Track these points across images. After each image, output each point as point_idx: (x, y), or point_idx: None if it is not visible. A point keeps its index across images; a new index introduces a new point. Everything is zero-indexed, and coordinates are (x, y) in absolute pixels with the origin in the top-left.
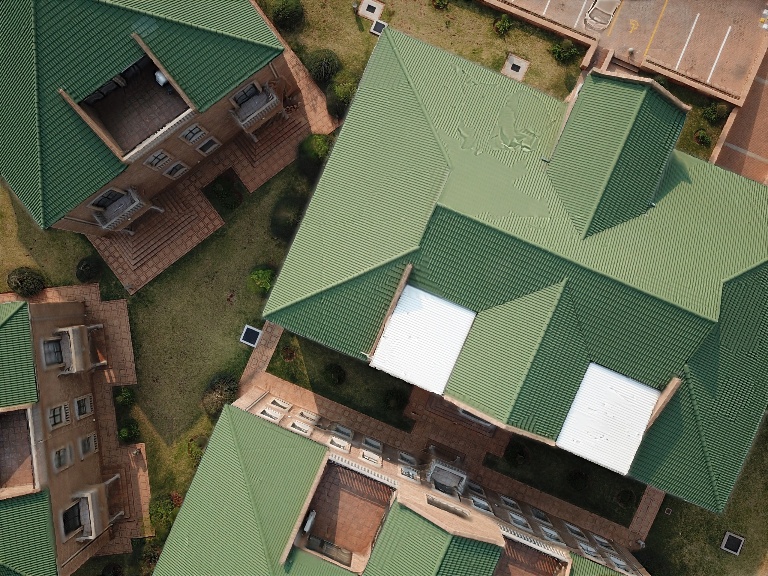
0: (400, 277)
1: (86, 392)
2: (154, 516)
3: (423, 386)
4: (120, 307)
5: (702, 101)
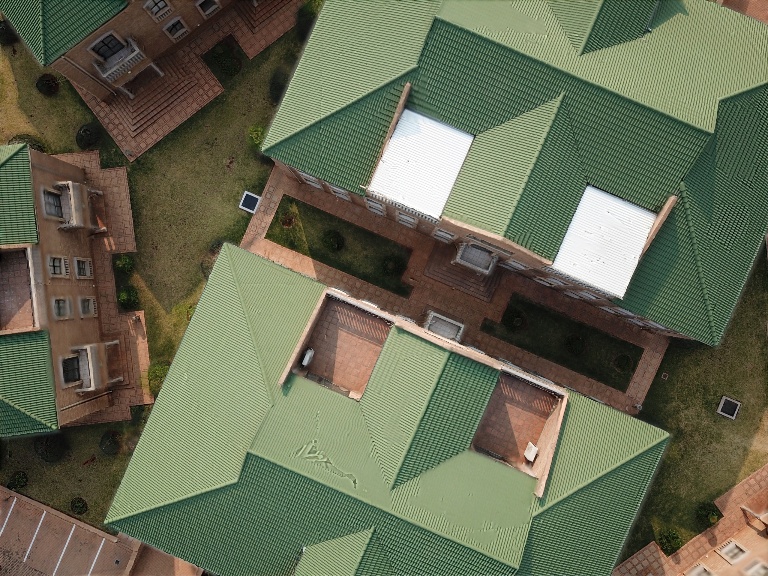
0: (398, 100)
1: (86, 256)
2: (153, 381)
3: (421, 209)
4: (120, 175)
5: None
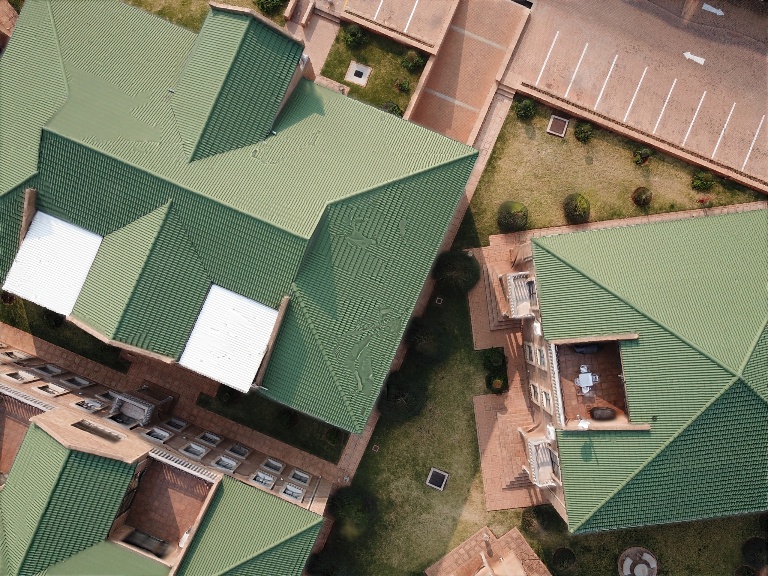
0: None
1: None
2: None
3: (52, 308)
4: None
5: (401, 50)
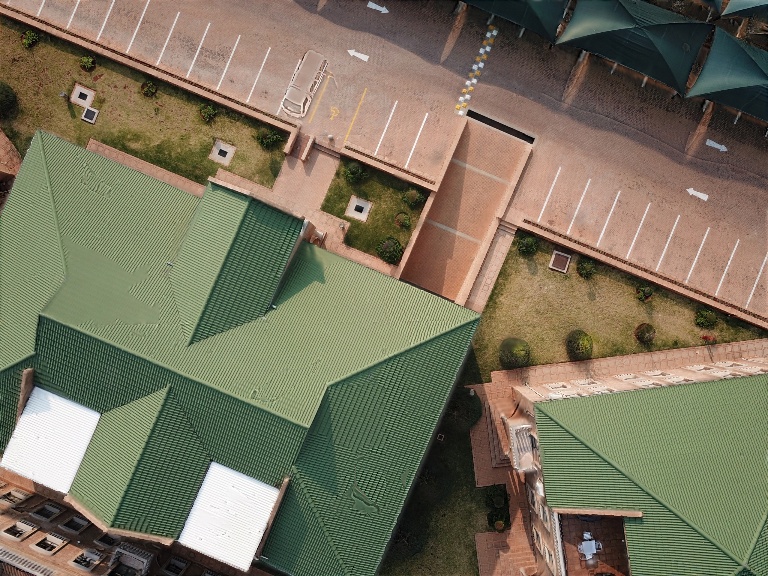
0: None
1: None
2: None
3: (50, 485)
4: None
5: (402, 185)
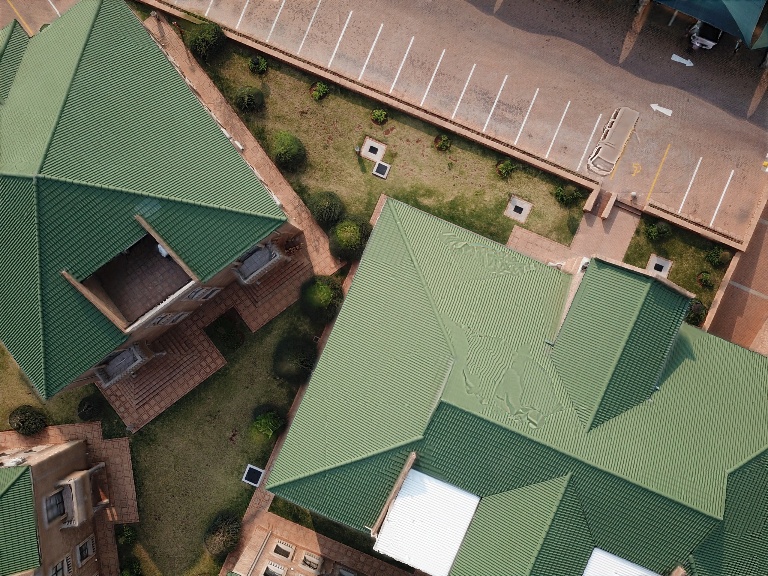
0: (404, 462)
1: (88, 534)
2: None
3: (427, 571)
4: (122, 445)
5: (705, 244)
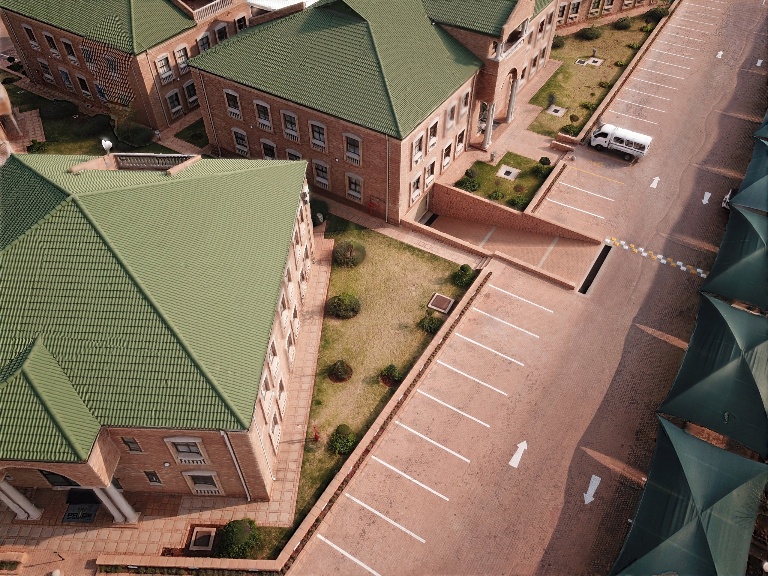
0: None
1: None
2: None
3: None
4: None
5: None
